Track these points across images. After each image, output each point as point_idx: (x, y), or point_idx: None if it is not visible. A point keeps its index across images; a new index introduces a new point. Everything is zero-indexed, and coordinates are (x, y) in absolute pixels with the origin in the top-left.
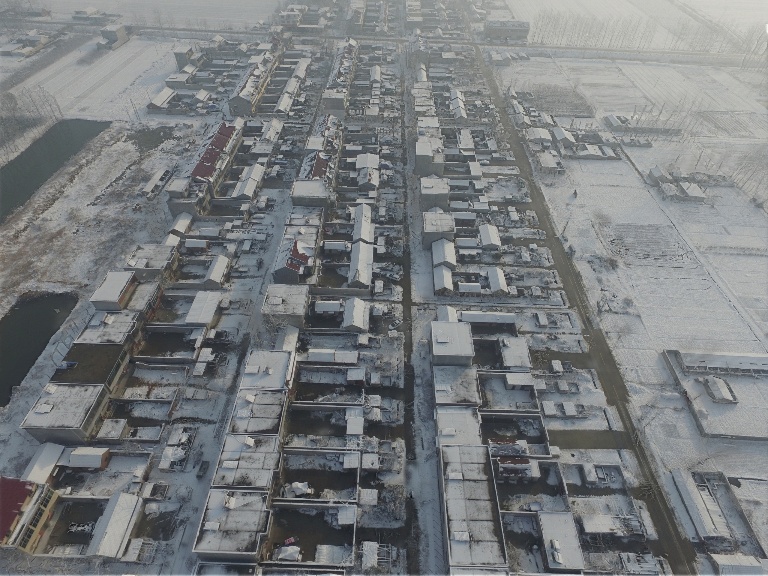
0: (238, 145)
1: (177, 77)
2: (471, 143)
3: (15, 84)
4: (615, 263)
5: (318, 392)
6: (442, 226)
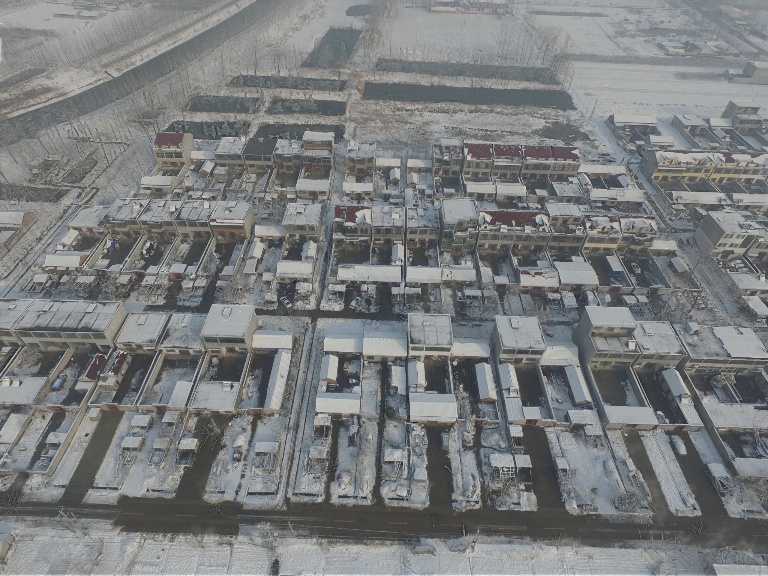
0: (559, 172)
1: (691, 119)
2: (732, 422)
3: (608, 61)
4: None
5: (225, 255)
6: (422, 331)
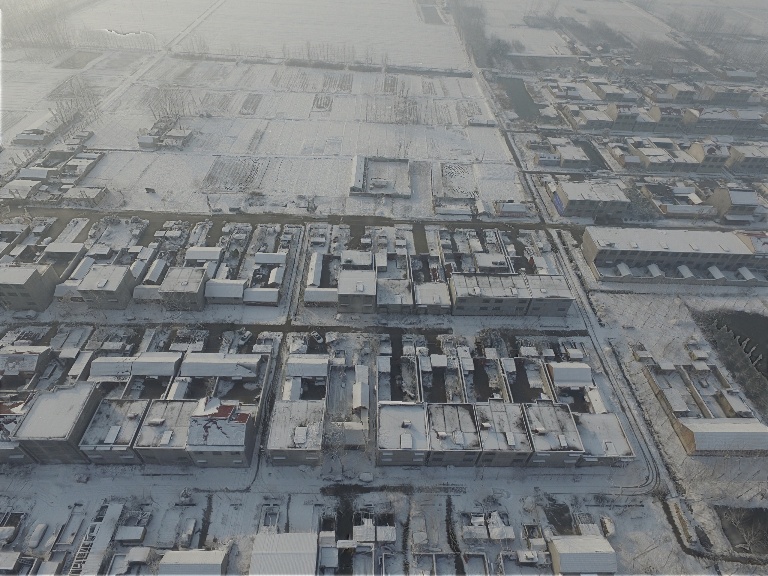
0: None
1: None
2: None
3: None
4: (256, 193)
5: (401, 400)
6: (192, 277)
